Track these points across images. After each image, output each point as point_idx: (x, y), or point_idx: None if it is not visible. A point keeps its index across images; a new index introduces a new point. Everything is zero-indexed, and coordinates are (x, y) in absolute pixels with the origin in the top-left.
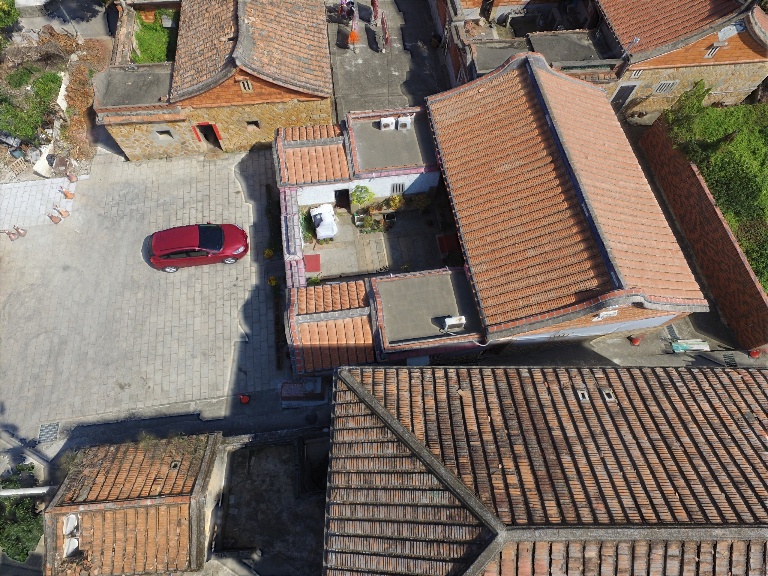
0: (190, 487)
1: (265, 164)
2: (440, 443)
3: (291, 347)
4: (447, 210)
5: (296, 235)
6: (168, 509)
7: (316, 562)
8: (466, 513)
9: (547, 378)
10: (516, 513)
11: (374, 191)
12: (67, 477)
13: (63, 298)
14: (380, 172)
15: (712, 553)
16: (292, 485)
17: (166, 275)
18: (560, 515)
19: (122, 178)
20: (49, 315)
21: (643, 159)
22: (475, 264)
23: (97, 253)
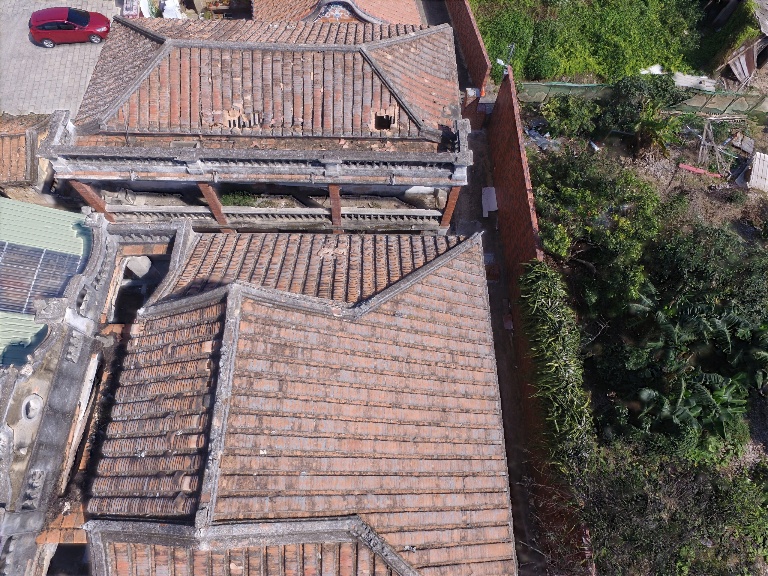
0: None
1: None
2: None
3: None
4: None
5: None
6: (11, 141)
7: None
8: (157, 45)
9: (255, 22)
10: None
11: None
12: None
13: None
14: None
15: (301, 60)
16: None
17: (46, 50)
18: None
19: None
20: None
21: None
22: None
23: None
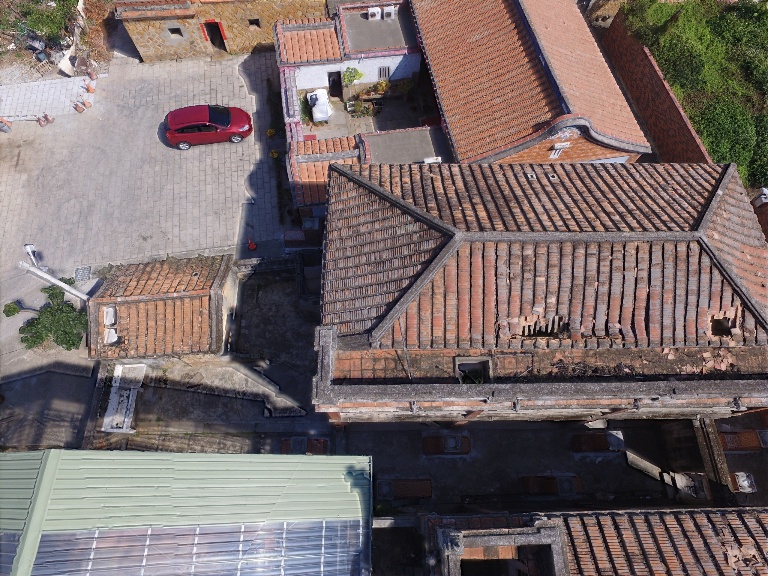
0: (209, 286)
1: (266, 63)
2: (413, 199)
3: (292, 184)
4: (429, 97)
5: (295, 103)
6: (191, 302)
7: (316, 368)
8: (432, 231)
9: (503, 168)
10: (470, 227)
11: (363, 75)
12: (105, 280)
13: (89, 171)
14: (368, 53)
15: (622, 252)
16: (295, 312)
17: (180, 152)
18: (505, 229)
19: (137, 76)
20: (78, 184)
21: (605, 55)
22: (450, 116)
23: (118, 136)
